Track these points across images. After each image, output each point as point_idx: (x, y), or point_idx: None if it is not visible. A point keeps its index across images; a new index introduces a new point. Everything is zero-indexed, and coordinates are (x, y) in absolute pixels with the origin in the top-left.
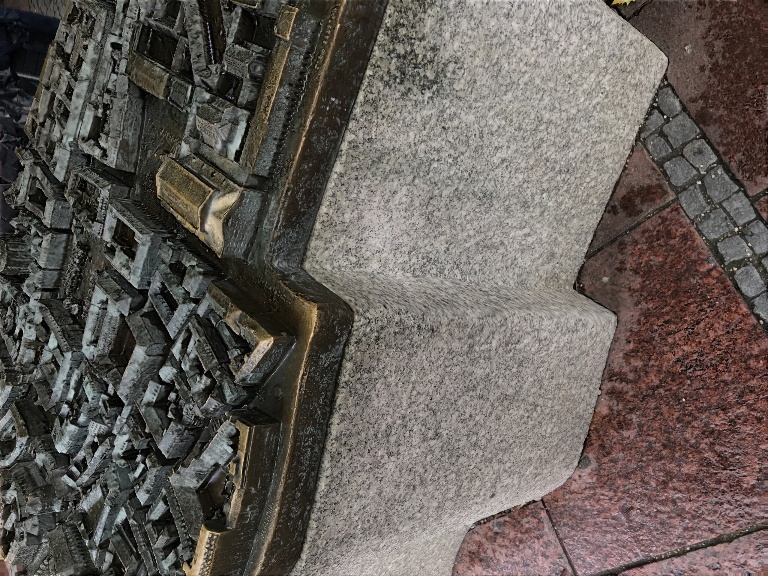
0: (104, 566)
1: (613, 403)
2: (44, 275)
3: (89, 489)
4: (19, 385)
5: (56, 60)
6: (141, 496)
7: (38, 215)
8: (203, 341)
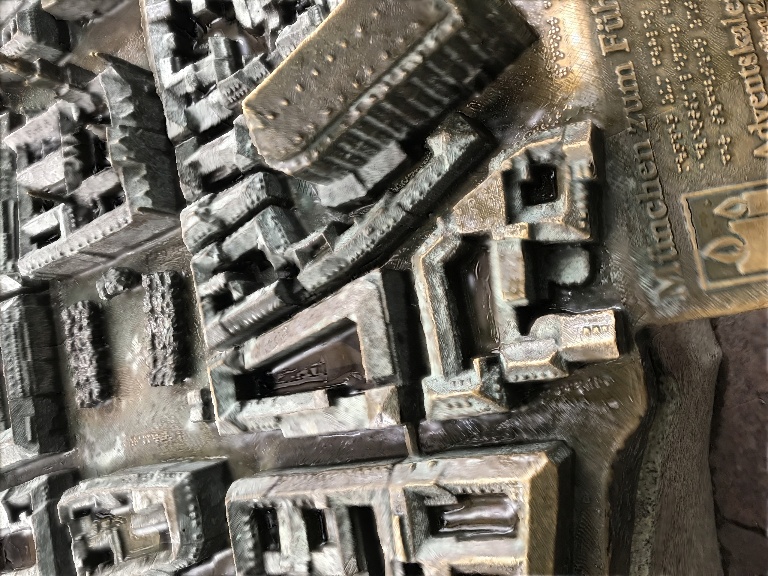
0: None
1: None
2: None
3: None
4: None
5: None
6: None
7: (281, 329)
8: None
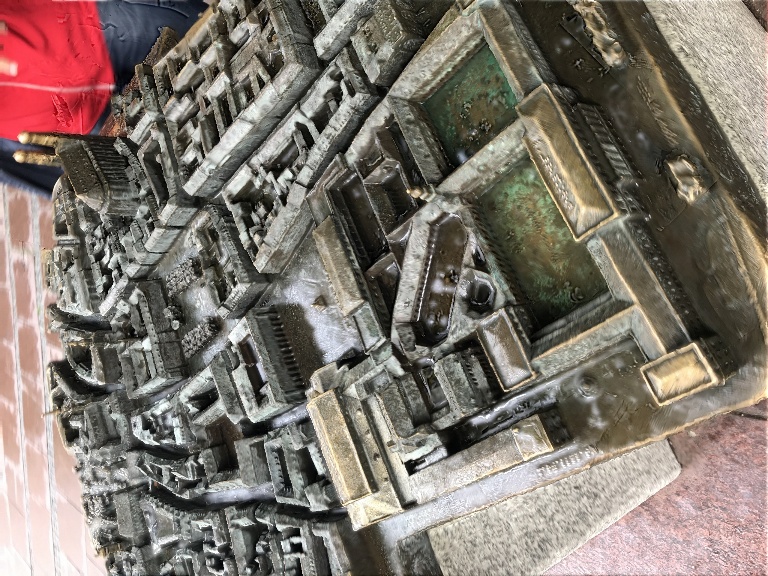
0: (163, 569)
1: (632, 522)
2: (147, 256)
3: (161, 503)
4: (99, 312)
5: (215, 42)
6: (211, 570)
7: None
8: (310, 555)
